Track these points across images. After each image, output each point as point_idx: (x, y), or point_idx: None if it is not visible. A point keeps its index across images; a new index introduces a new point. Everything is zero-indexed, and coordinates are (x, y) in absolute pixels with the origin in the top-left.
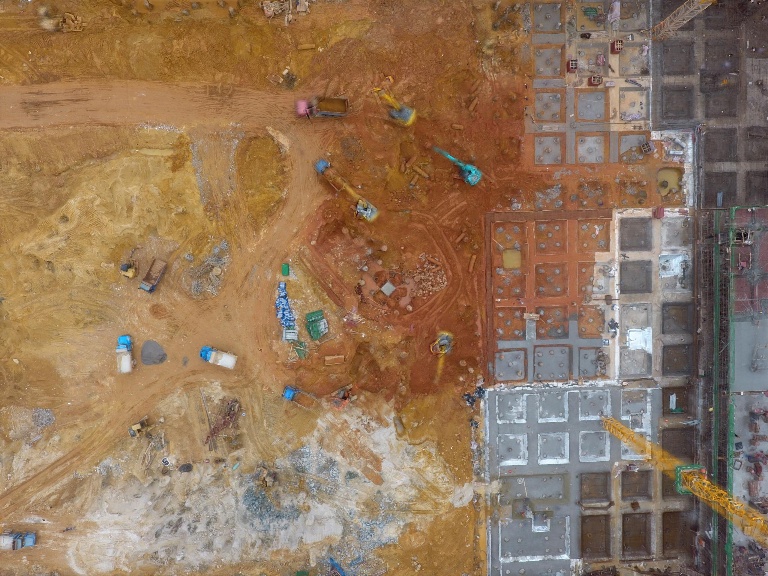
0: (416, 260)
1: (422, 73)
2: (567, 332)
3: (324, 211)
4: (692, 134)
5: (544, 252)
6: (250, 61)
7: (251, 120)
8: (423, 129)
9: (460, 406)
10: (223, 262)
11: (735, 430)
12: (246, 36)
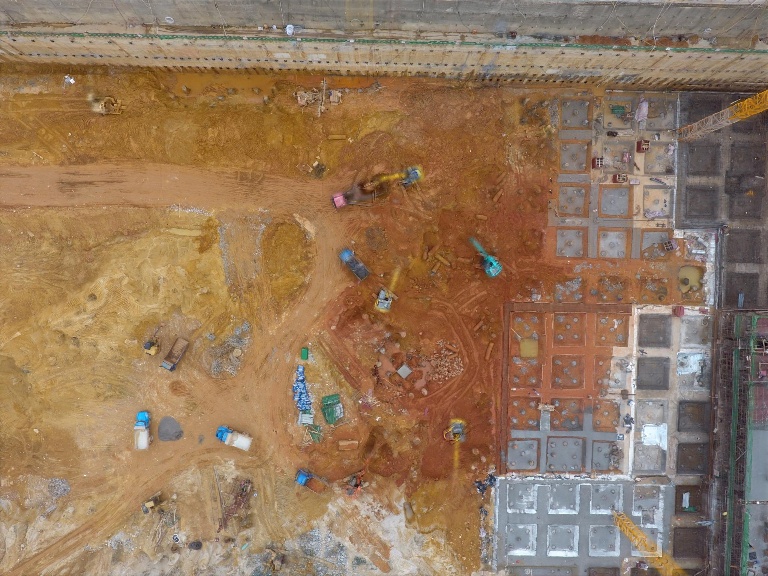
0: (434, 346)
1: (449, 168)
2: (581, 424)
3: (346, 298)
4: (715, 234)
5: (562, 343)
6: (281, 150)
7: (279, 206)
8: (447, 220)
9: (470, 493)
10: (244, 343)
11: (749, 539)
12: (279, 126)
